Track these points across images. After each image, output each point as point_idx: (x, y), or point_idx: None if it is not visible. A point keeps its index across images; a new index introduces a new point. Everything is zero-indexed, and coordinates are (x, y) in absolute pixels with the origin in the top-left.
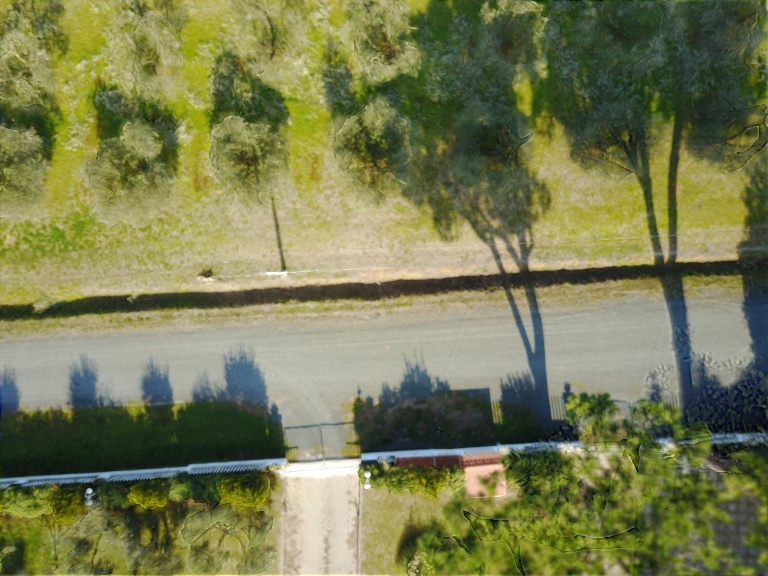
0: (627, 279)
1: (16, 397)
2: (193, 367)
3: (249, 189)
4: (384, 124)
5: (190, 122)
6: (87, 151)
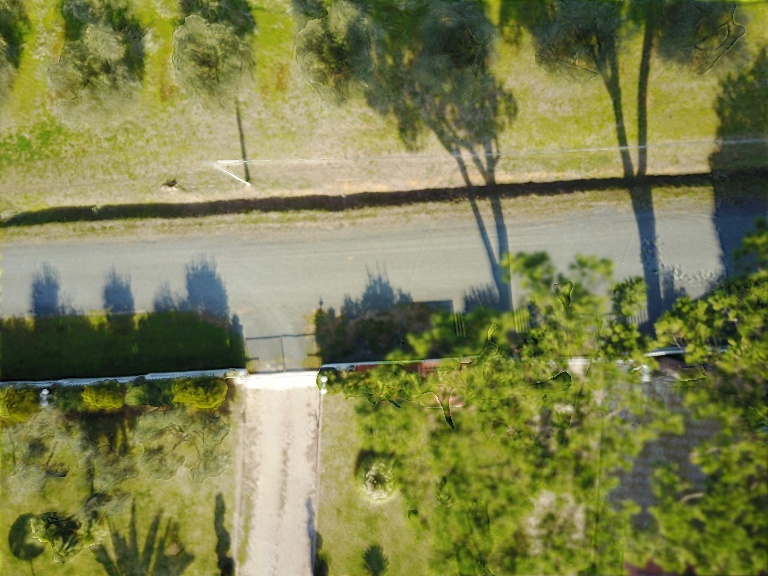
0: (595, 191)
1: None
2: (155, 276)
3: (210, 90)
4: (346, 25)
5: (156, 31)
6: (54, 60)
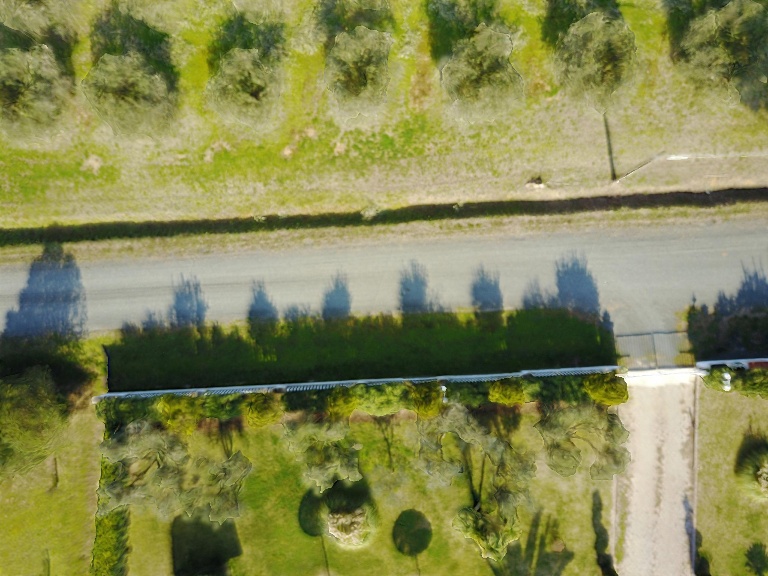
0: None
1: (348, 302)
2: (524, 274)
3: (607, 87)
4: (747, 21)
5: (523, 29)
6: (418, 59)
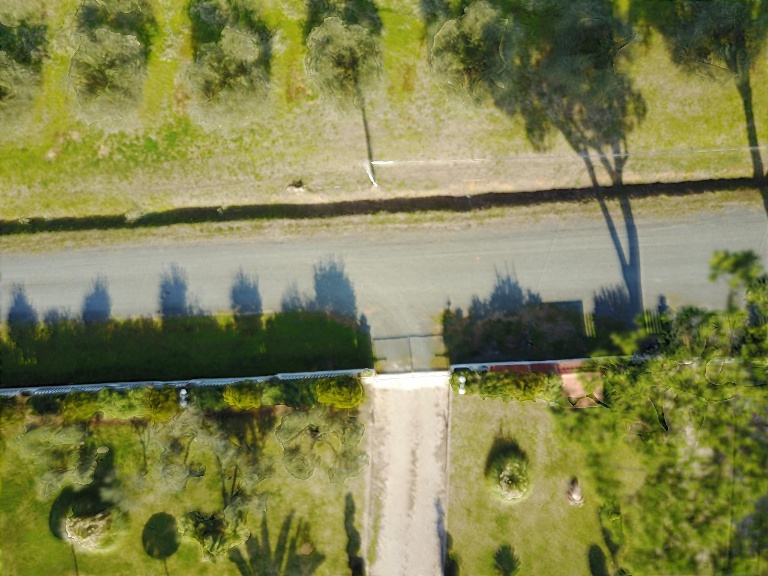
0: (726, 191)
1: (108, 304)
2: (282, 277)
3: (346, 92)
4: (483, 26)
5: (283, 33)
6: (181, 62)
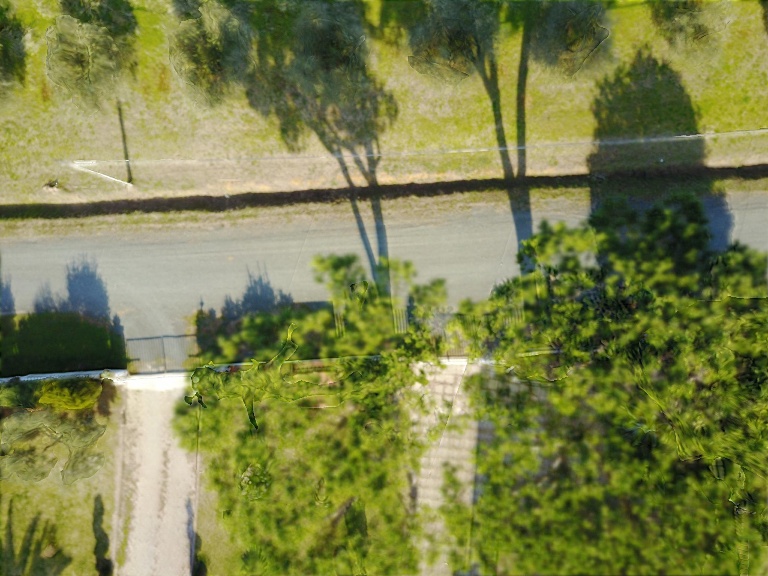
0: (474, 192)
1: None
2: (36, 277)
3: (82, 90)
4: (218, 26)
5: (37, 31)
6: None
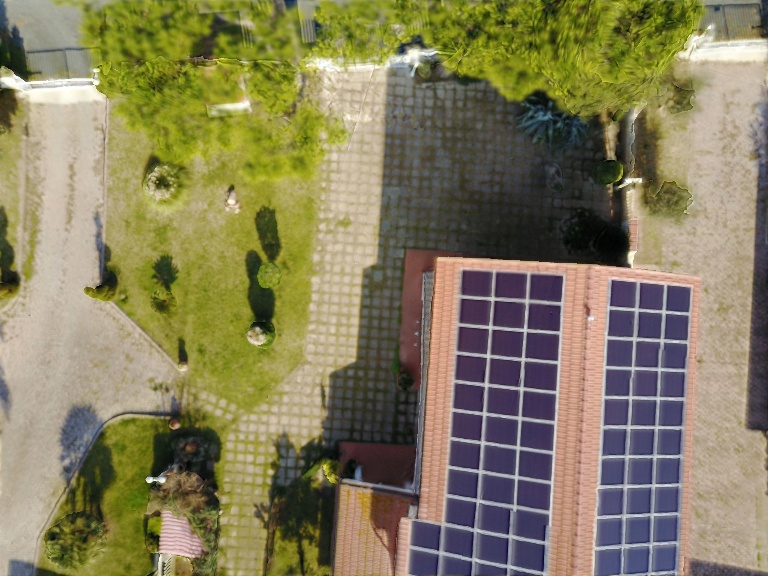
0: None
1: None
2: None
3: None
4: None
5: None
6: None
